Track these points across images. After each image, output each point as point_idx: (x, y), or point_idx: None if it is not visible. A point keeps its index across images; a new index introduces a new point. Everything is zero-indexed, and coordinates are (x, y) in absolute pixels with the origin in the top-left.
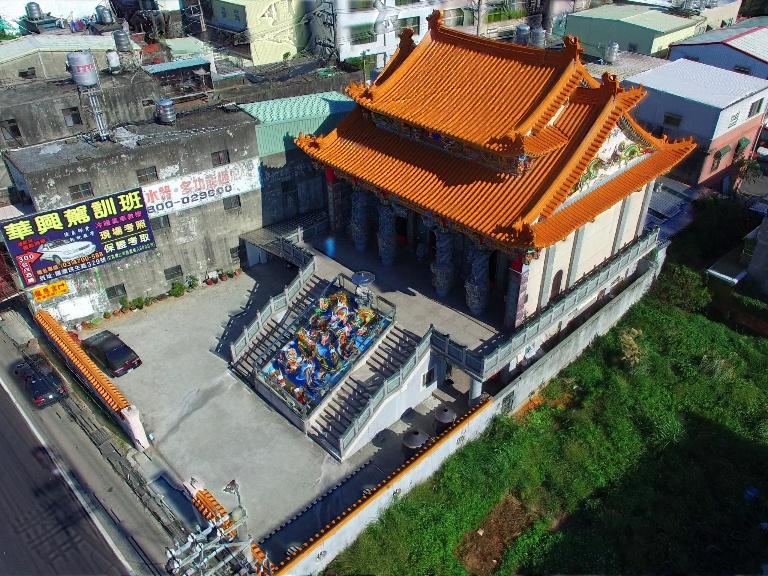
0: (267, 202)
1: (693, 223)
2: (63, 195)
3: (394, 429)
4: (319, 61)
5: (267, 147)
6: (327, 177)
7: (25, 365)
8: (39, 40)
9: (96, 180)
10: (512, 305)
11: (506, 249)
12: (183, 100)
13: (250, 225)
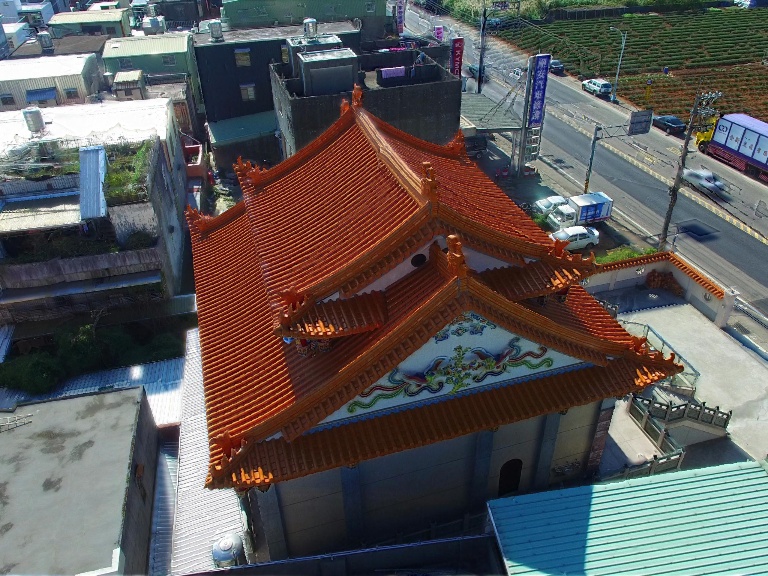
0: None
1: (107, 358)
2: None
3: None
4: None
5: None
6: None
7: None
8: None
9: None
10: None
11: None
12: None
13: None
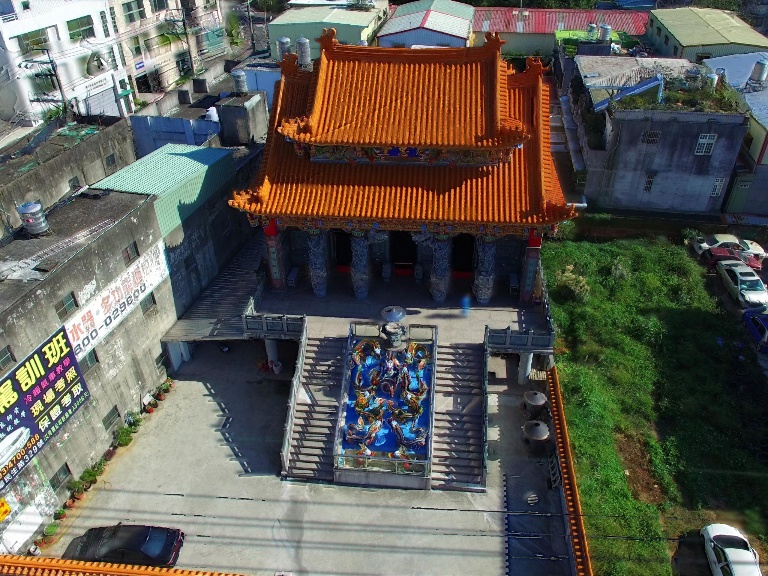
0: (176, 289)
1: None
2: None
3: (491, 438)
4: (56, 120)
5: (166, 224)
6: (266, 232)
7: None
8: None
9: (15, 339)
10: (530, 279)
11: (521, 231)
12: None
13: (167, 323)
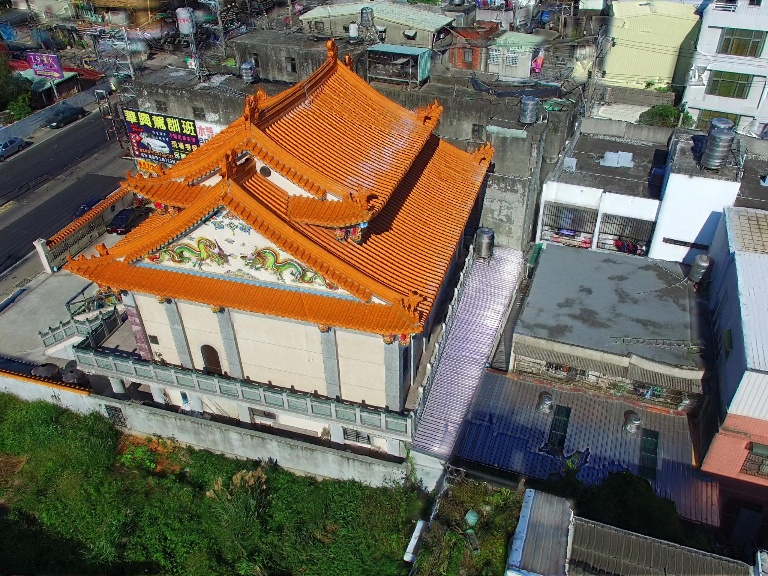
0: None
1: None
2: (152, 104)
3: None
4: (556, 90)
5: None
6: None
7: None
8: (377, 5)
9: (169, 102)
10: None
11: None
12: (401, 82)
13: None
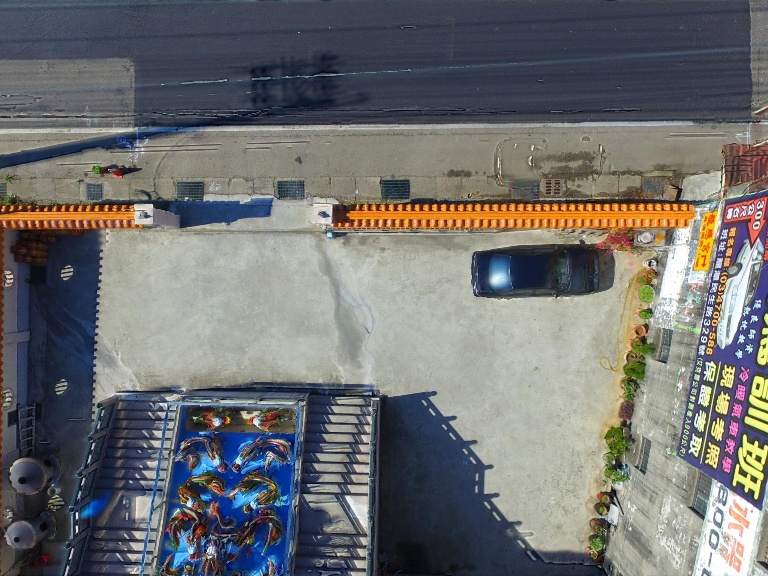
0: None
1: None
2: None
3: None
4: None
5: None
6: None
7: (625, 164)
8: None
9: None
10: None
11: None
12: None
13: None
